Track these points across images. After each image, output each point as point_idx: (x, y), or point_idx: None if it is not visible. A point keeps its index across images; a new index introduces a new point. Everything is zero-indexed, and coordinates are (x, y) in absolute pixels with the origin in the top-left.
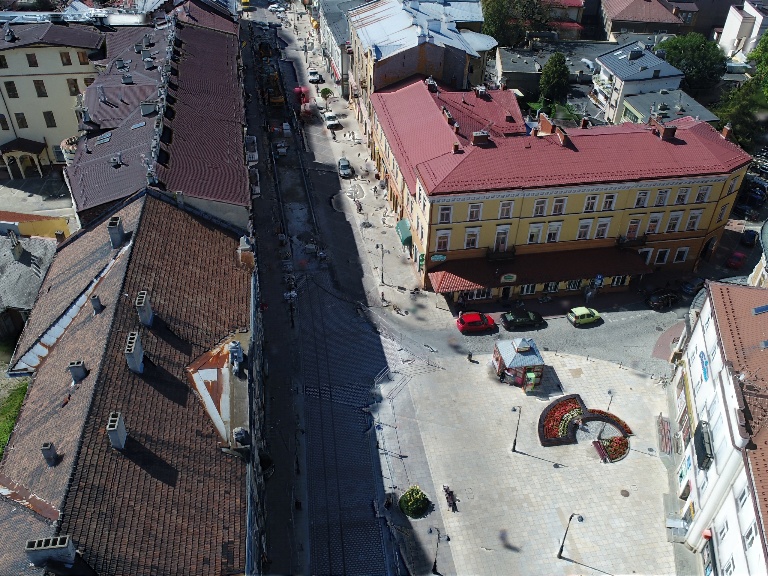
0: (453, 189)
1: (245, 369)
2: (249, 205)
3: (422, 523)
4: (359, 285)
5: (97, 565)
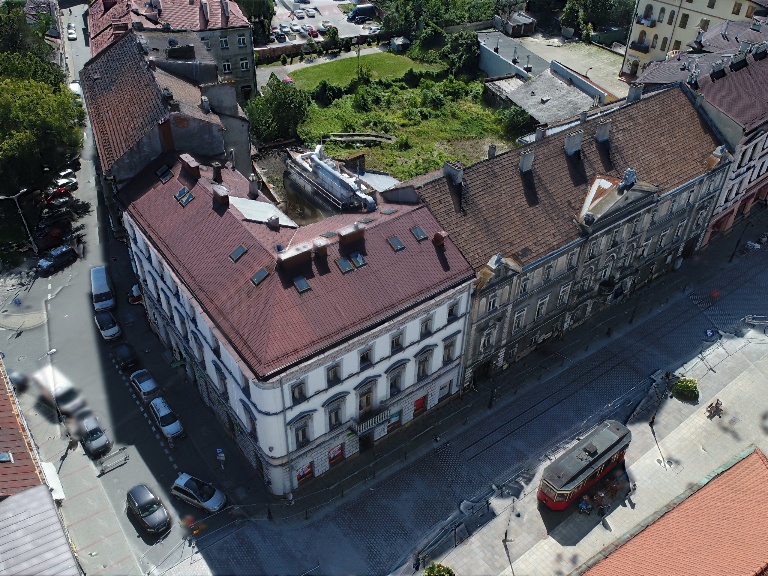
0: None
1: (626, 190)
2: (748, 129)
3: (677, 402)
4: None
5: (465, 195)
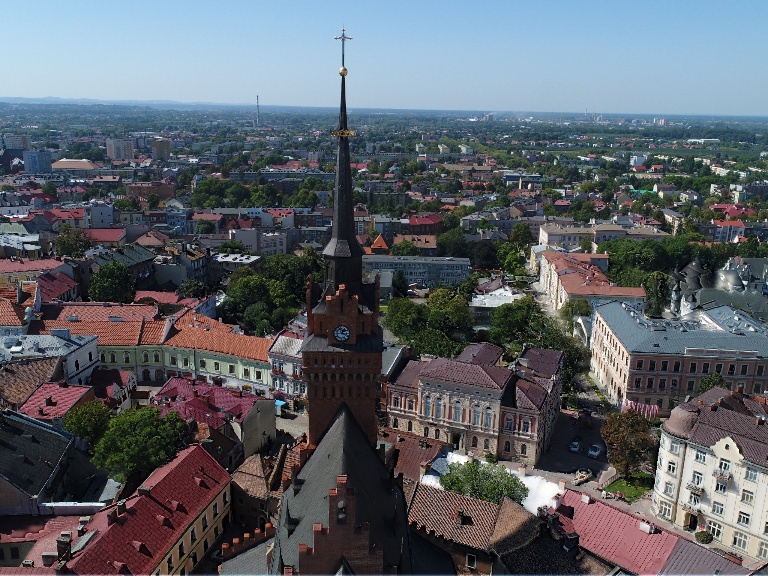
0: None
1: None
2: None
3: None
4: None
5: None
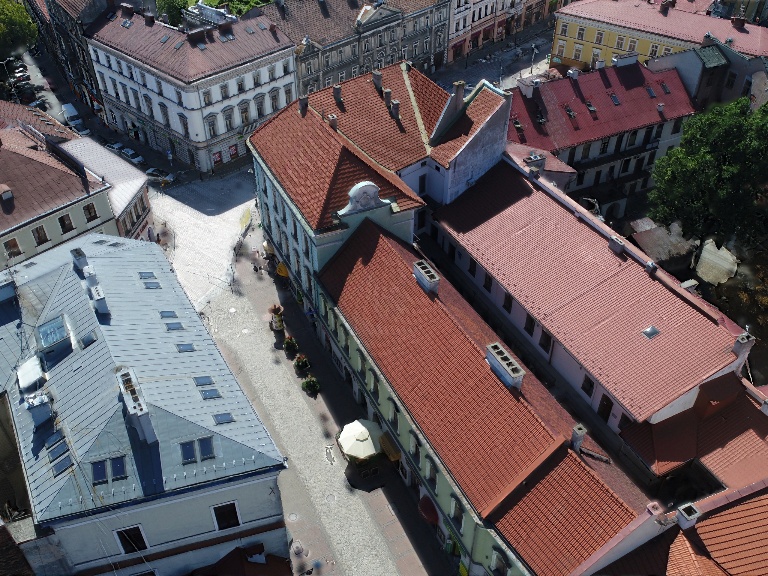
0: (571, 13)
1: (378, 7)
2: None
3: None
4: (519, 70)
5: (287, 11)
